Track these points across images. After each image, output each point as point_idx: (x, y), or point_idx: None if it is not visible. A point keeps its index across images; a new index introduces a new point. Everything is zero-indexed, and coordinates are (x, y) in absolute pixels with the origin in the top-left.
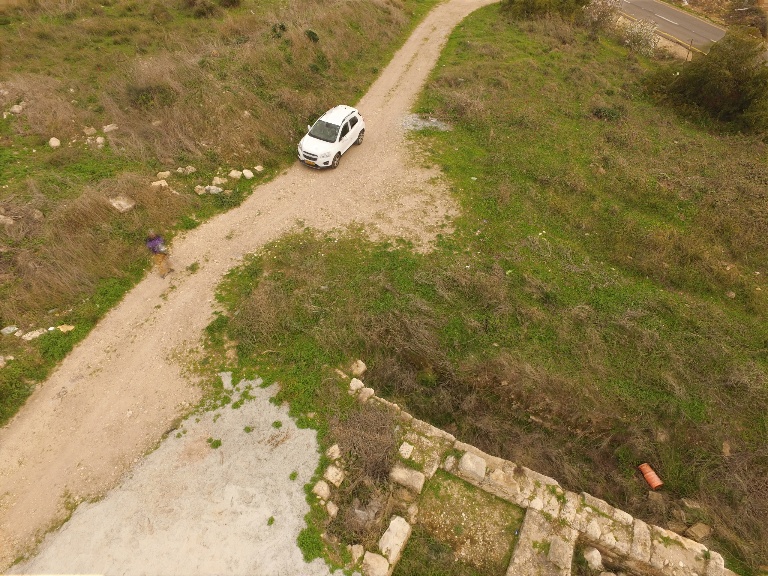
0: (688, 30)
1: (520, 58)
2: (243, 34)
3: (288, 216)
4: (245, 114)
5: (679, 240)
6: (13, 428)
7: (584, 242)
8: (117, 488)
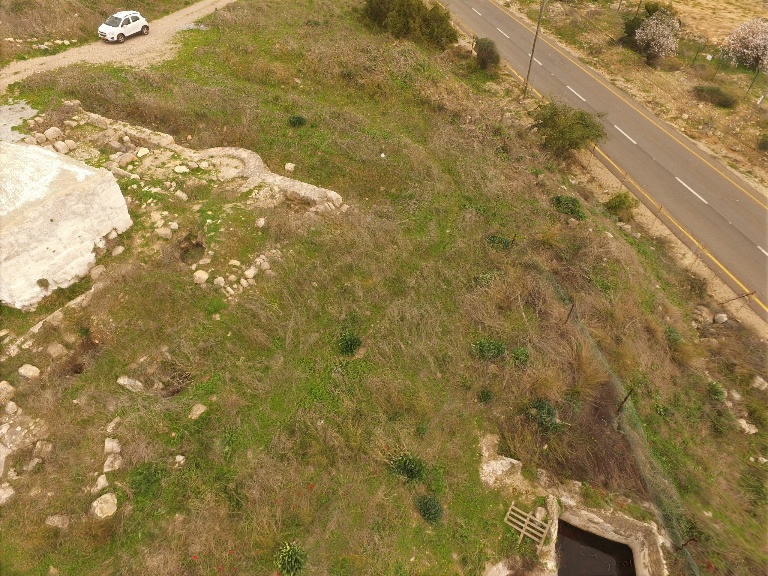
0: None
1: None
2: None
3: (79, 59)
4: (75, 15)
5: None
6: None
7: None
8: None
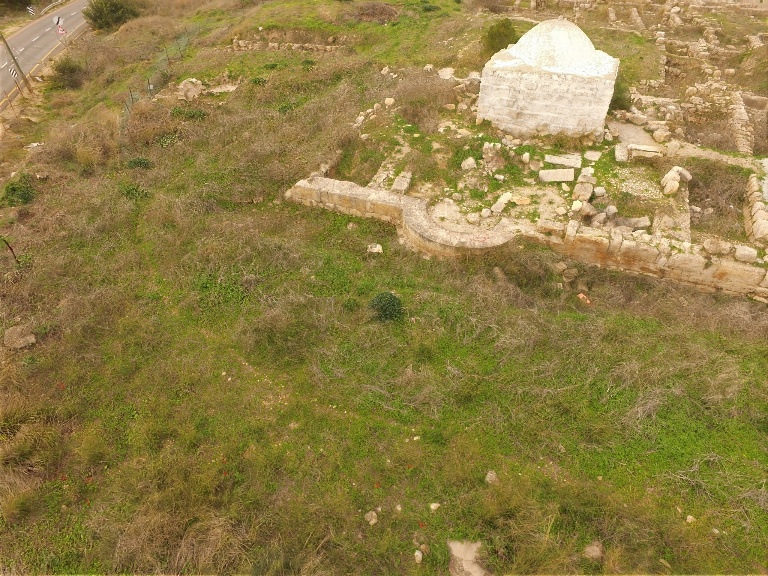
0: None
1: None
2: None
3: None
4: None
5: None
6: None
7: None
8: None
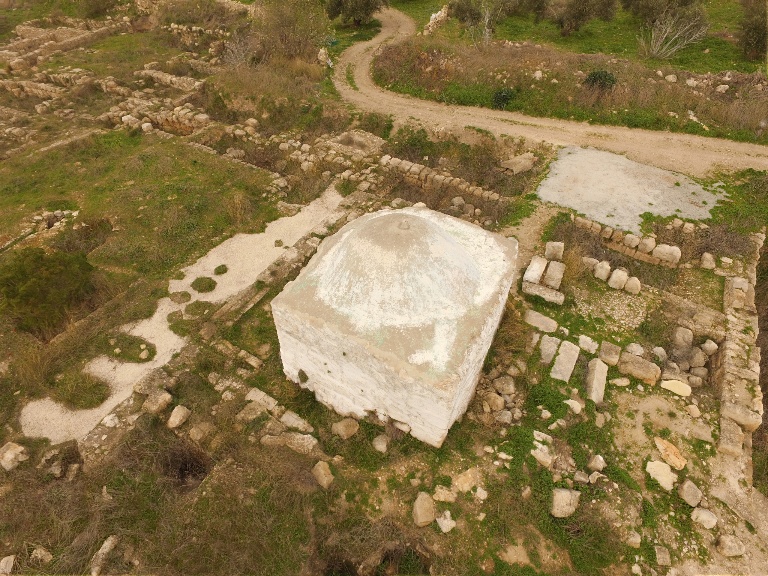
0: None
1: None
2: None
3: None
4: None
5: None
6: (644, 132)
7: None
8: (637, 162)
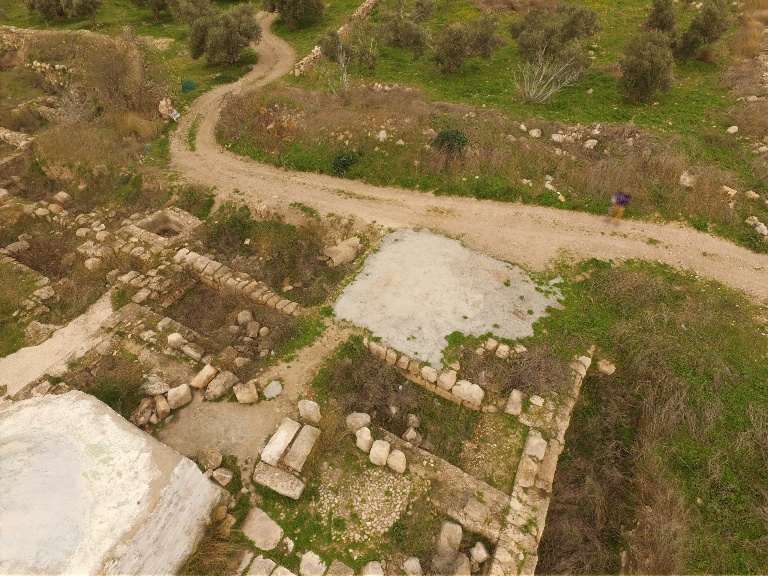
0: None
1: None
2: None
3: None
4: None
5: None
6: (493, 205)
7: None
8: (471, 251)
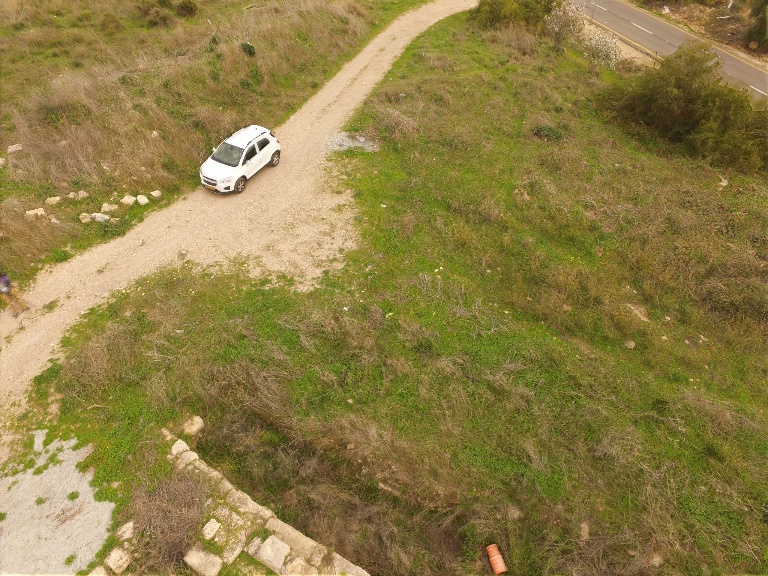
0: (662, 40)
1: (473, 71)
2: (184, 46)
3: (172, 247)
4: (153, 134)
5: (586, 280)
6: None
7: (483, 280)
8: None
